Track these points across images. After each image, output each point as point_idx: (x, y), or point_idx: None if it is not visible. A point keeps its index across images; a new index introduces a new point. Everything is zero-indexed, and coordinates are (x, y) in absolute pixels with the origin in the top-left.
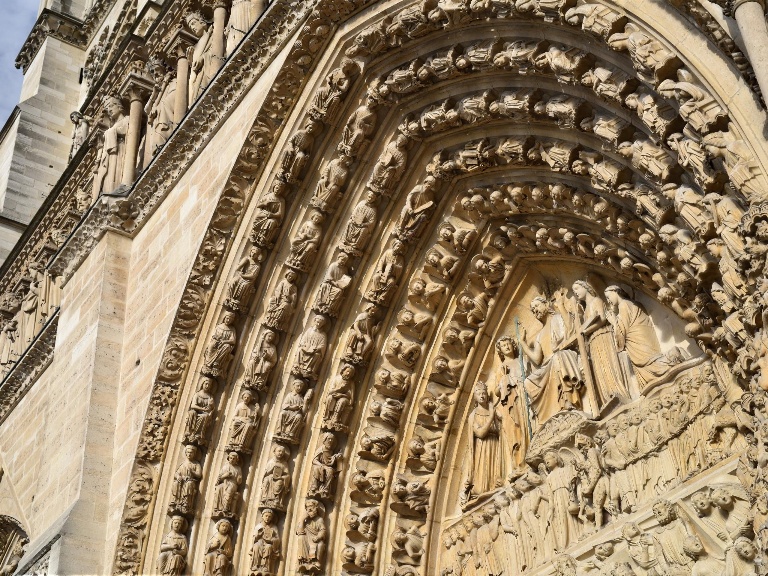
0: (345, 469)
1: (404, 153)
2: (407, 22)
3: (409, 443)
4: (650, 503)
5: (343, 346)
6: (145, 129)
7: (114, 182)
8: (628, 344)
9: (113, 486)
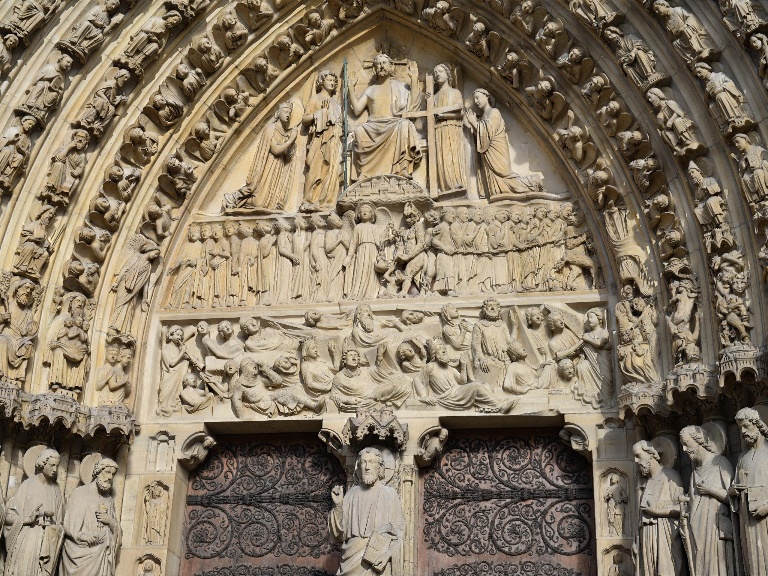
0: (121, 115)
1: None
2: None
3: (197, 122)
4: (475, 296)
5: None
6: None
7: None
8: (491, 150)
9: None
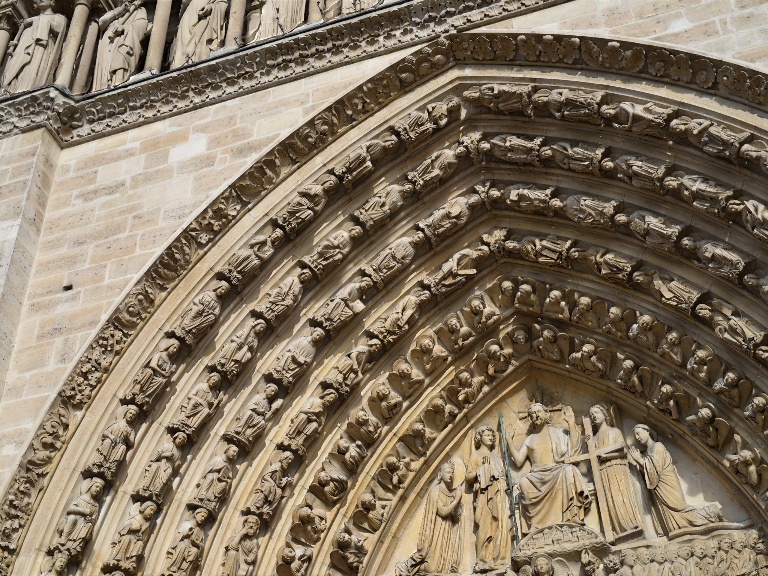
0: (289, 496)
1: (470, 213)
2: (573, 102)
3: (362, 494)
4: None
5: (327, 369)
6: (83, 39)
7: (36, 76)
8: (661, 485)
9: (4, 414)
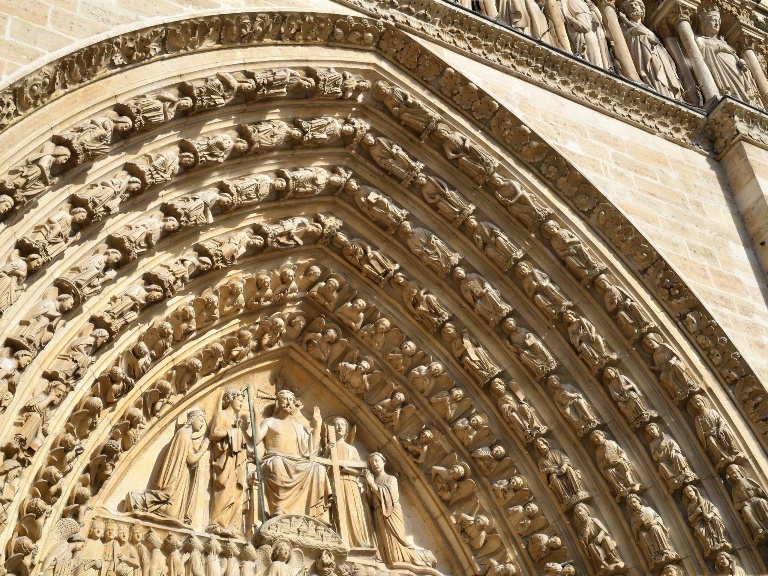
0: None
1: None
2: (476, 154)
3: None
4: None
5: (156, 263)
6: None
7: None
8: (394, 516)
9: None
